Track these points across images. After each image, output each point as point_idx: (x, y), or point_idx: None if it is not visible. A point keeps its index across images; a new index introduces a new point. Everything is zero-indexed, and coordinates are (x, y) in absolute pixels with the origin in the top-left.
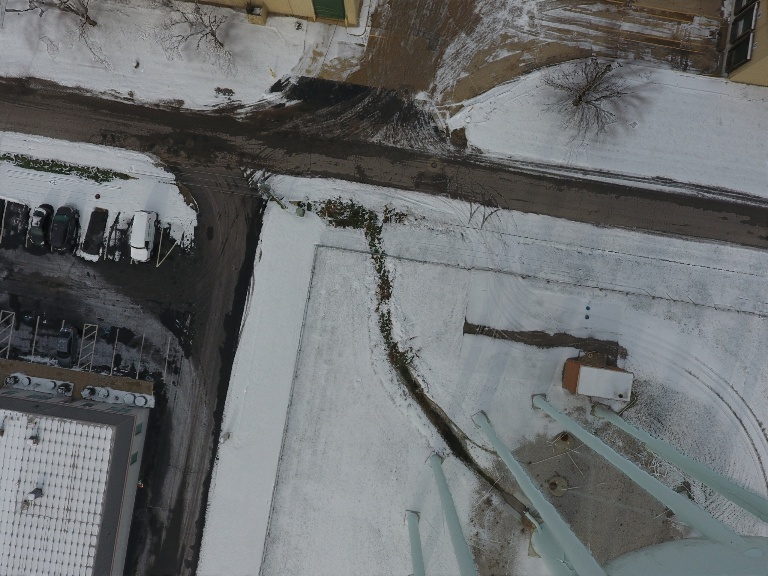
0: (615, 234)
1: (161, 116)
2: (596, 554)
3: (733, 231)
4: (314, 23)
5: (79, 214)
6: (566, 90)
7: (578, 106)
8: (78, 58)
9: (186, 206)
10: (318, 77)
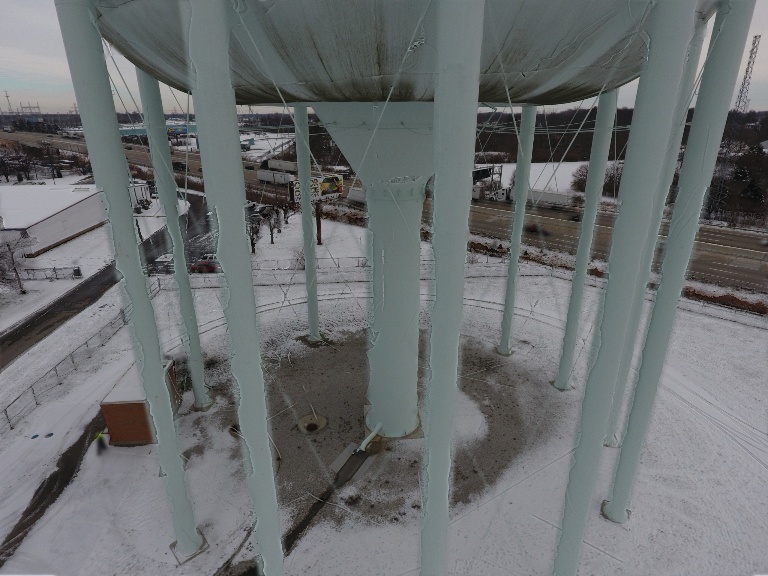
0: None
1: None
2: None
3: (16, 348)
4: None
5: None
6: None
7: None
8: None
9: None
10: None
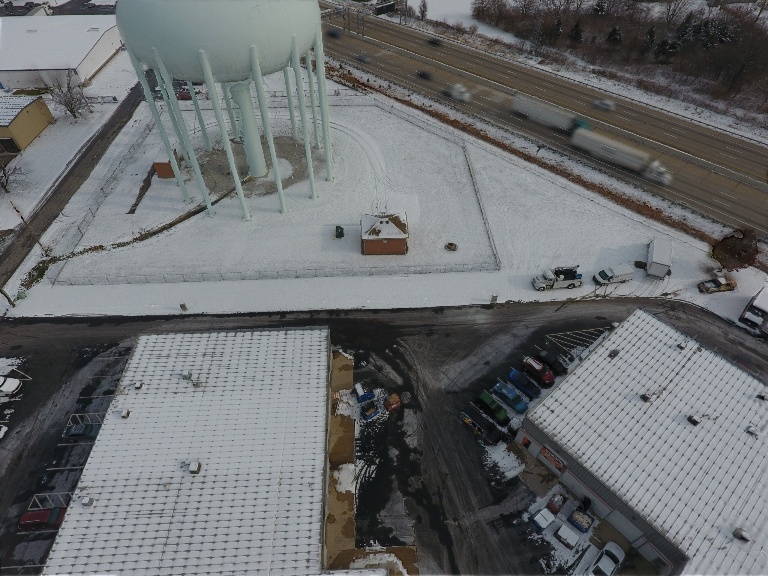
0: (94, 173)
1: None
2: (265, 159)
3: None
4: None
5: None
6: None
7: (10, 192)
8: None
9: None
10: None
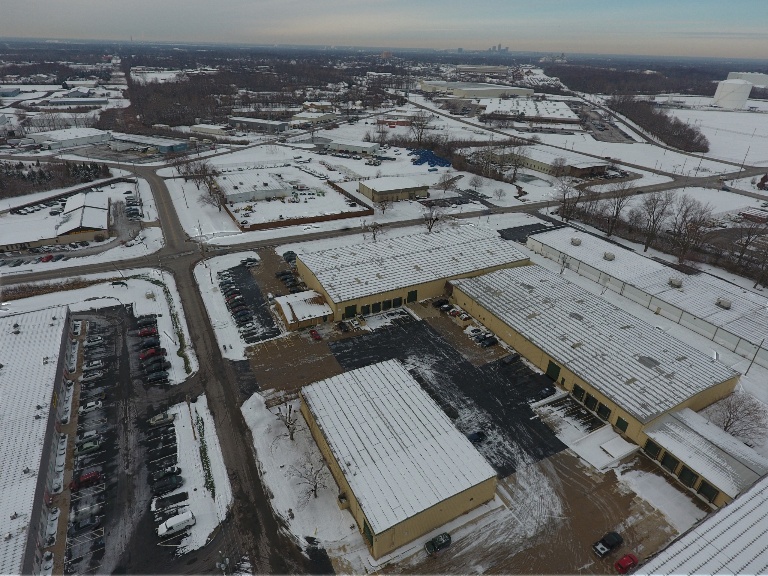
0: None
1: (259, 492)
2: None
3: None
4: (360, 534)
5: (181, 487)
6: None
7: None
8: (271, 442)
9: (207, 537)
10: (330, 559)
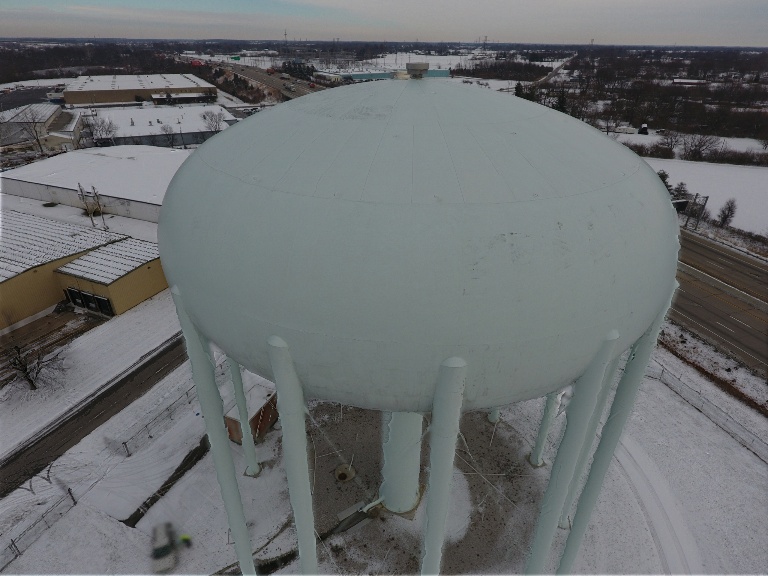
0: (157, 387)
1: None
2: (424, 456)
3: None
4: None
5: None
6: (7, 381)
7: (38, 388)
8: None
9: None
10: None
